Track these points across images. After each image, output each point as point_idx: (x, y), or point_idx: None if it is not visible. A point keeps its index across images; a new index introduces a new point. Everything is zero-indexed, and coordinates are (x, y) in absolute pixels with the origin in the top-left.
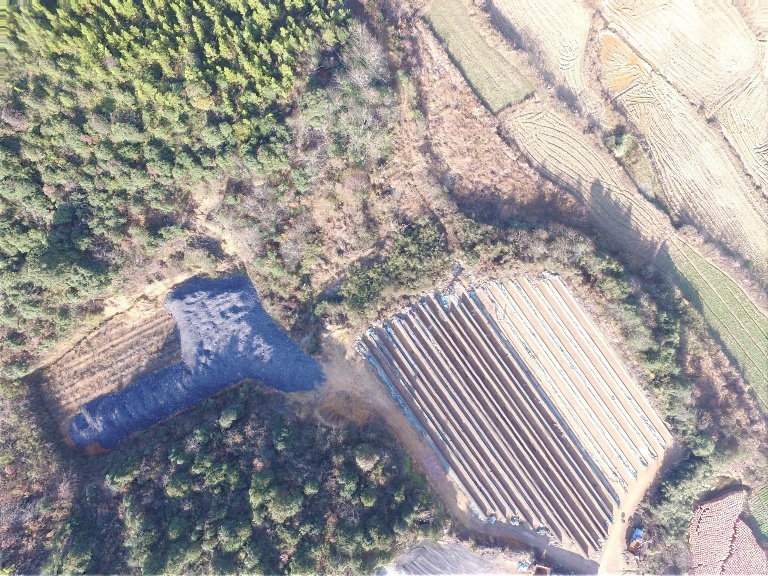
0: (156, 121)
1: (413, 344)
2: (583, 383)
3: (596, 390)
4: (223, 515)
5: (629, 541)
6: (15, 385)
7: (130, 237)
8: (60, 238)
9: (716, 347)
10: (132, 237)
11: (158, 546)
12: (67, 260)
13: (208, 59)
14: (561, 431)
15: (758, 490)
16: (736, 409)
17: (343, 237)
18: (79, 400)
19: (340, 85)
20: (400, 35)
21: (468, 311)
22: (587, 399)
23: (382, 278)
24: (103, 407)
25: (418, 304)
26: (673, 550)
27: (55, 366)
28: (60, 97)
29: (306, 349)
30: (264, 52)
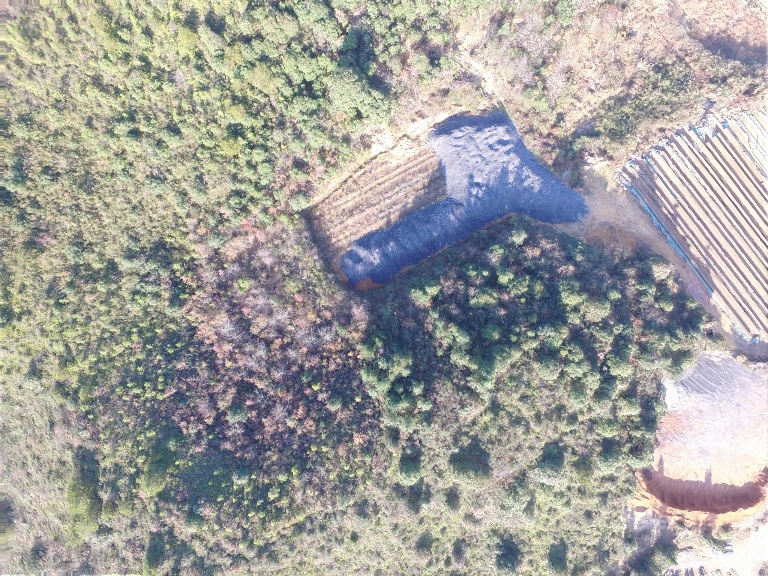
0: None
1: (673, 173)
2: None
3: None
4: (535, 320)
5: None
6: (295, 218)
7: (409, 66)
8: (351, 62)
9: None
10: (411, 66)
11: (473, 352)
12: None
13: None
14: None
15: None
16: None
17: (593, 77)
18: (349, 237)
19: None
20: None
21: (725, 140)
22: None
23: (637, 113)
24: (376, 241)
25: (674, 136)
26: None
27: (324, 204)
28: None
29: (568, 183)
30: None
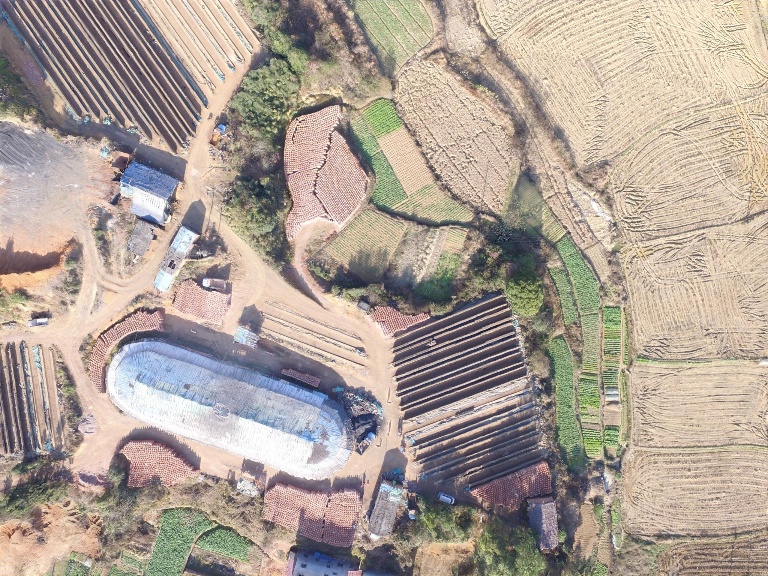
0: None
1: None
2: None
3: (188, 1)
4: None
5: (212, 136)
6: None
7: None
8: None
9: None
10: None
11: None
12: None
13: None
14: (153, 38)
15: (362, 111)
16: (329, 24)
17: None
18: None
19: None
20: None
21: None
22: (180, 9)
23: None
24: None
25: None
26: (251, 141)
27: None
28: None
29: None
30: None
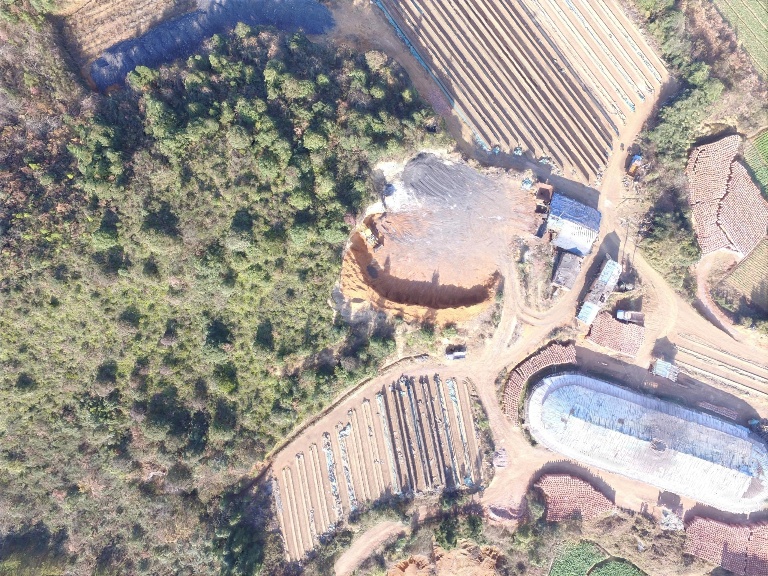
0: None
1: None
2: (581, 23)
3: (594, 29)
4: None
5: (628, 167)
6: (39, 19)
7: None
8: None
9: (709, 4)
10: None
11: None
12: None
13: None
14: (561, 67)
15: (752, 140)
16: (729, 53)
17: None
18: (99, 45)
19: None
20: None
21: None
22: (585, 38)
23: None
24: (122, 47)
25: None
26: (671, 172)
27: (76, 14)
28: None
29: None
30: None
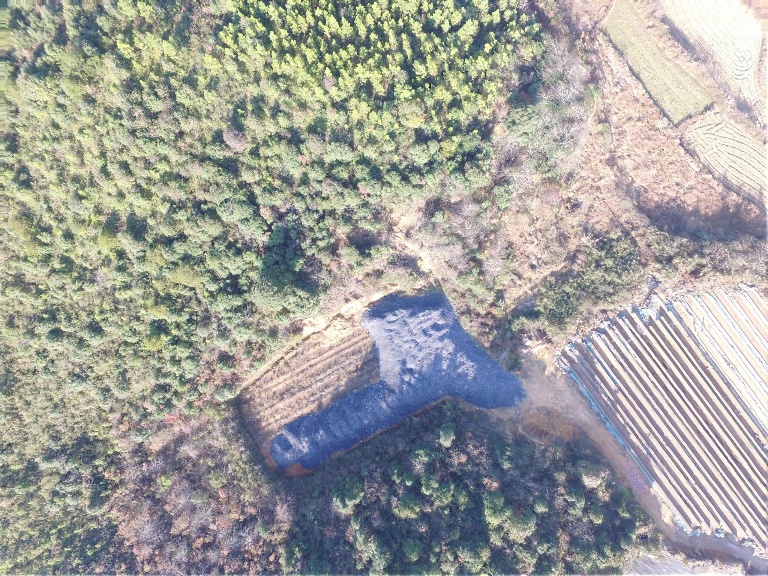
0: (364, 140)
1: (614, 358)
2: None
3: None
4: (457, 536)
5: None
6: (222, 408)
7: (339, 257)
8: (276, 260)
9: None
10: (341, 257)
11: (393, 568)
12: (289, 282)
13: (418, 76)
14: (763, 442)
15: None
16: None
17: (535, 252)
18: (279, 421)
19: (545, 101)
20: (586, 48)
21: (668, 324)
22: None
23: (579, 293)
24: (306, 428)
25: (616, 318)
26: None
27: (254, 387)
28: (279, 118)
29: (505, 365)
30: (469, 68)
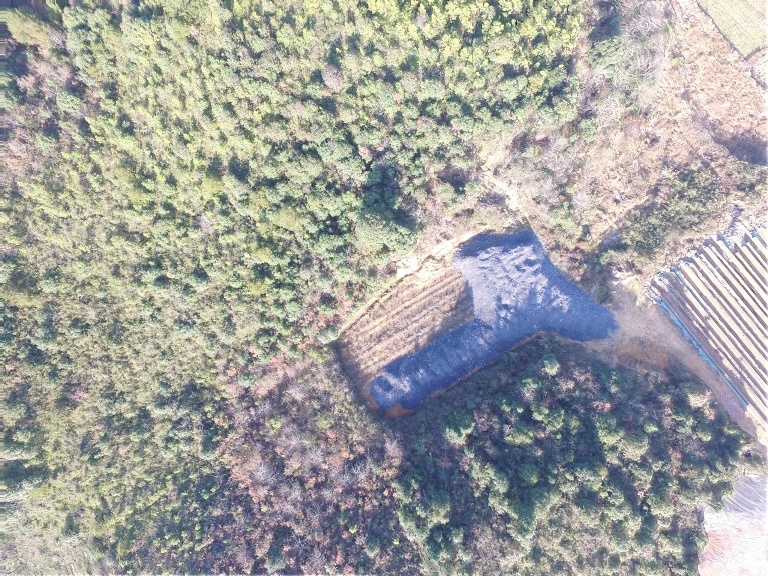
0: (454, 78)
1: (703, 286)
2: None
3: None
4: (572, 458)
5: None
6: (324, 351)
7: (434, 195)
8: (376, 198)
9: None
10: (436, 195)
11: (511, 493)
12: None
13: (505, 13)
14: None
15: None
16: None
17: (618, 187)
18: (378, 363)
19: (628, 33)
20: None
21: (755, 250)
22: None
23: (664, 224)
24: (406, 368)
25: (702, 247)
26: None
27: (351, 331)
28: (375, 56)
29: (596, 298)
30: (553, 4)
